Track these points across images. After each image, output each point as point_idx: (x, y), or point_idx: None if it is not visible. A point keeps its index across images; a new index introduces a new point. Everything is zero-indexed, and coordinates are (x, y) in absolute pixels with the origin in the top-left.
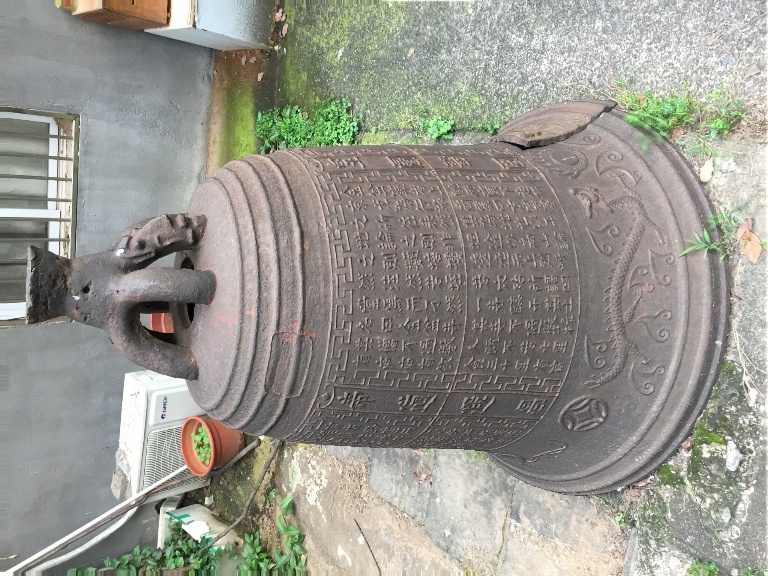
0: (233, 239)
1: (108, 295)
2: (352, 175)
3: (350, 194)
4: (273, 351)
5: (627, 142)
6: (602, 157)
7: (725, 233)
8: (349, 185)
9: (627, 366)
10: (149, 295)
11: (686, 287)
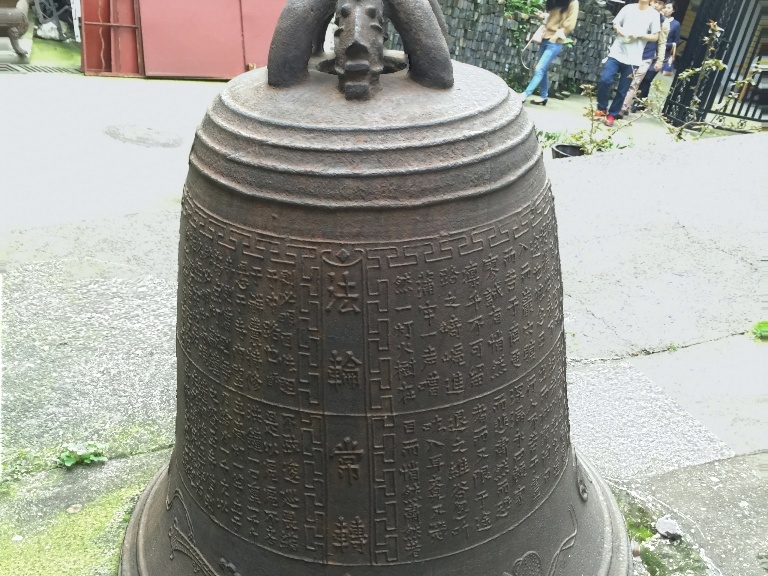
0: None
1: None
2: None
3: None
4: None
5: None
6: None
7: None
8: None
9: None
10: None
11: None
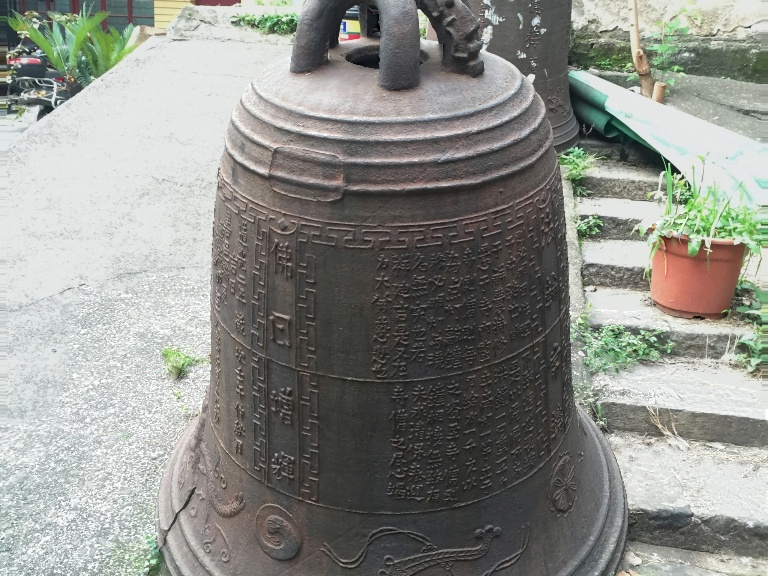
0: None
1: None
2: None
3: None
4: None
5: None
6: None
7: None
8: None
9: None
10: None
11: None
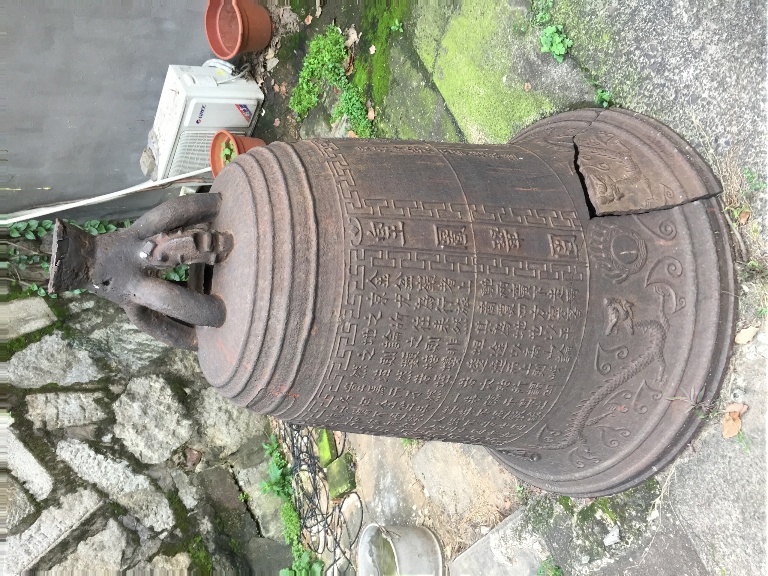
0: (249, 295)
1: (126, 294)
2: (387, 256)
3: (376, 283)
4: (259, 395)
5: (697, 258)
6: (662, 263)
7: (720, 397)
8: (379, 271)
9: (571, 447)
10: (162, 312)
11: (655, 424)
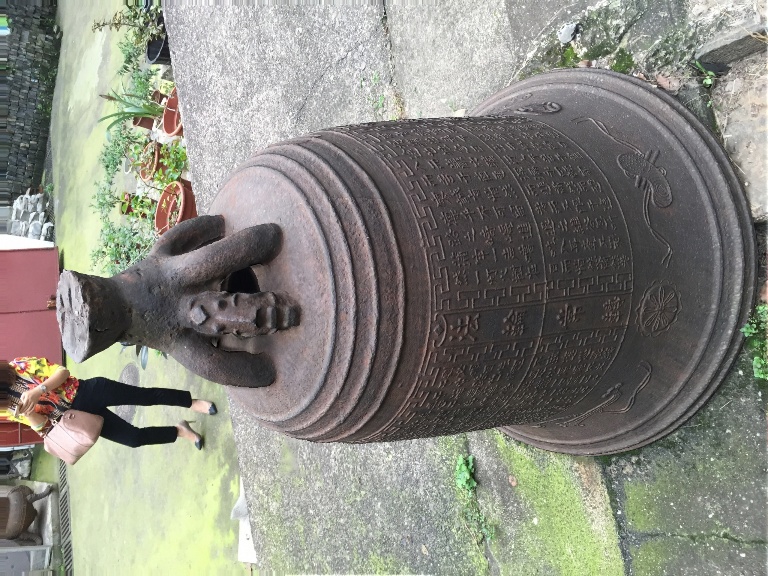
0: None
1: None
2: None
3: None
4: None
5: None
6: None
7: None
8: None
9: None
10: (170, 233)
11: None
